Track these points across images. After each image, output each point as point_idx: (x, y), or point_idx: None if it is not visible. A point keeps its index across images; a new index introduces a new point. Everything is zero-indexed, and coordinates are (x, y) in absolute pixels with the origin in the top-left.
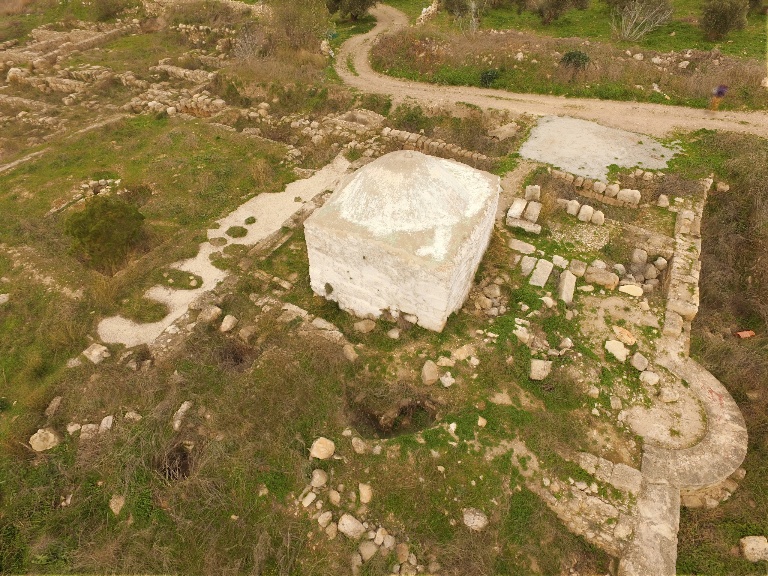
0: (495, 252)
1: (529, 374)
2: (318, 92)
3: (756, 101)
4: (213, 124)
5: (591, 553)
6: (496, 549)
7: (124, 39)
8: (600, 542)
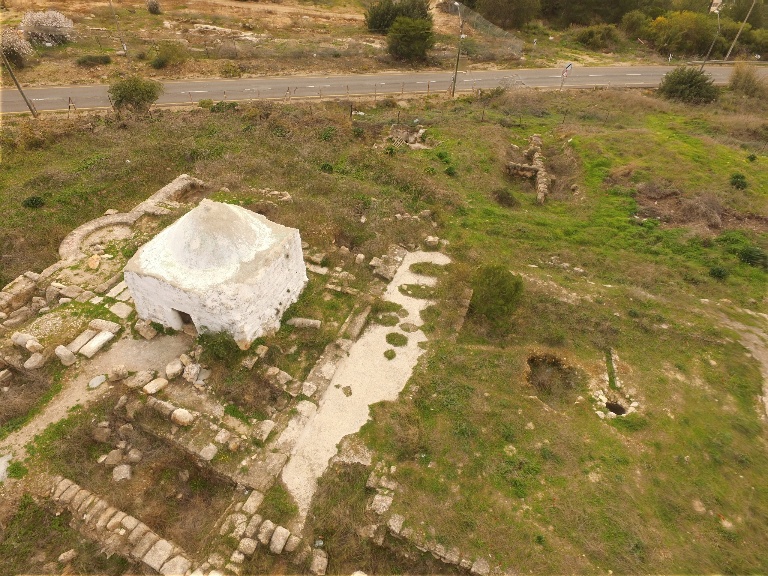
0: None
1: None
2: None
3: None
4: None
5: None
6: None
7: None
8: None
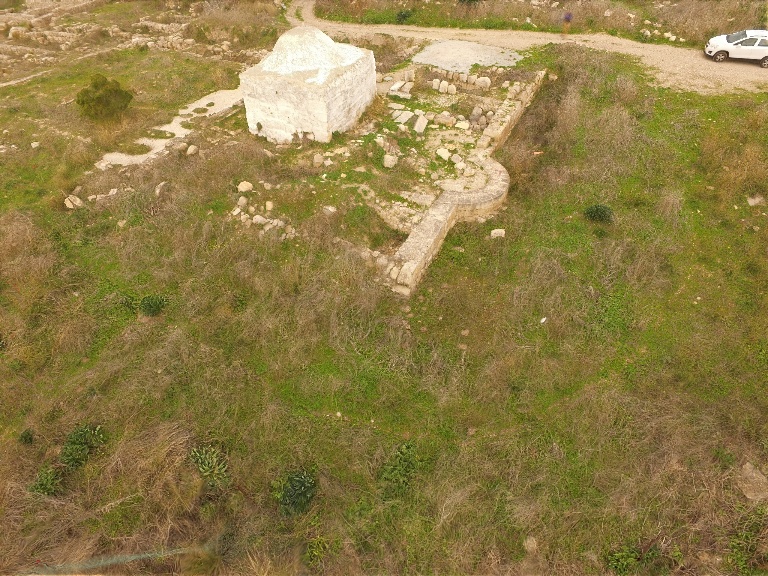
0: (374, 106)
1: (383, 163)
2: (270, 32)
3: (597, 26)
4: (184, 53)
5: (400, 235)
6: (342, 227)
7: (109, 6)
8: (406, 229)
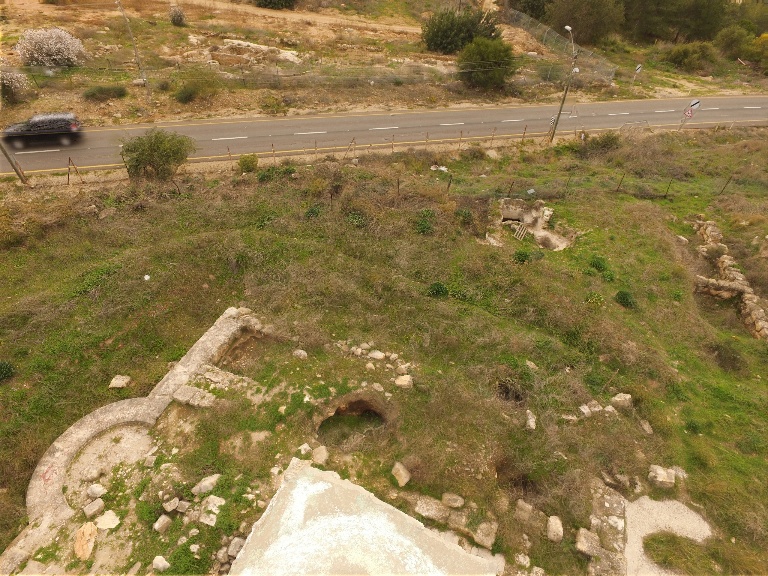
0: None
1: None
2: None
3: None
4: None
5: (230, 368)
6: None
7: None
8: None
